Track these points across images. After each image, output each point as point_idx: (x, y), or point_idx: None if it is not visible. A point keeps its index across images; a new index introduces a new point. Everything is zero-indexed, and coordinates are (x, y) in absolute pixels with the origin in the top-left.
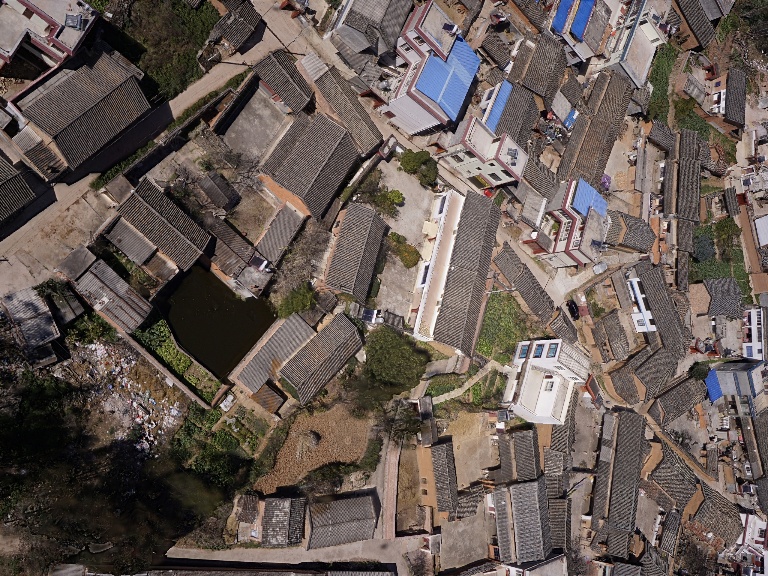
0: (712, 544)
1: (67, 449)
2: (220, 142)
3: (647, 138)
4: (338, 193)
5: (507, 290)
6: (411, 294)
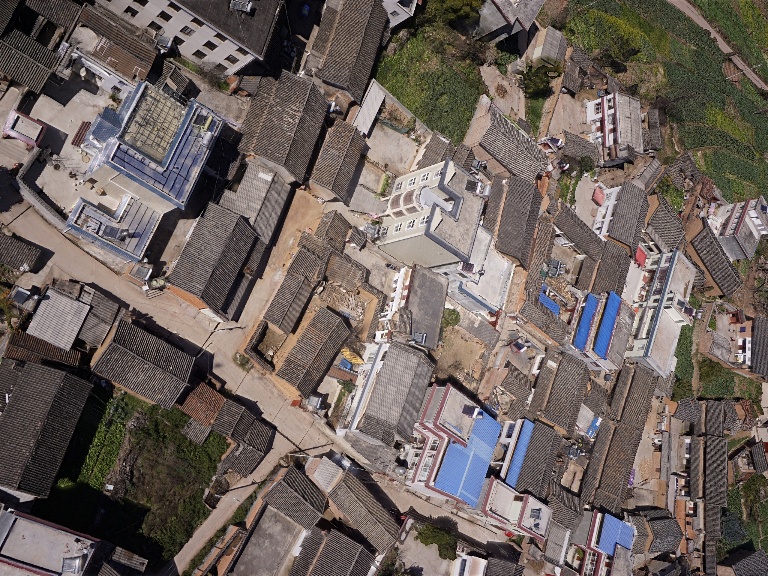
0: None
1: None
2: None
3: (672, 415)
4: None
5: None
6: None
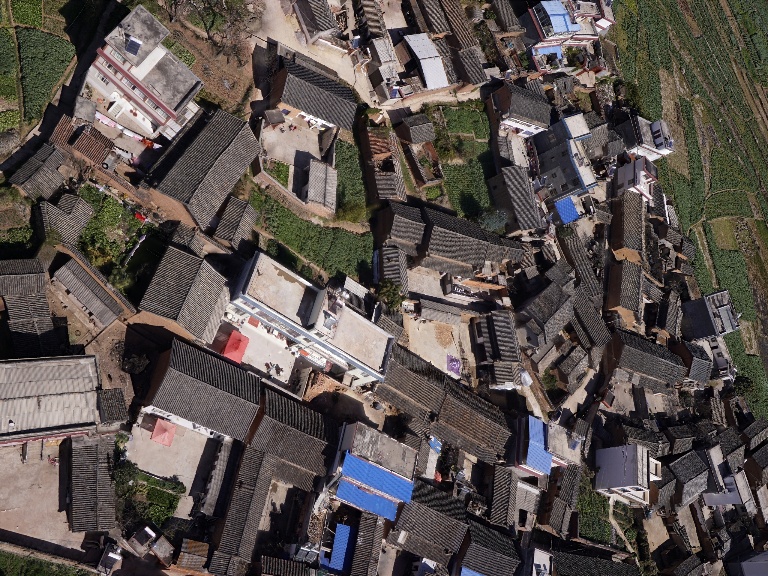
0: None
1: None
2: None
3: None
4: None
5: None
6: None
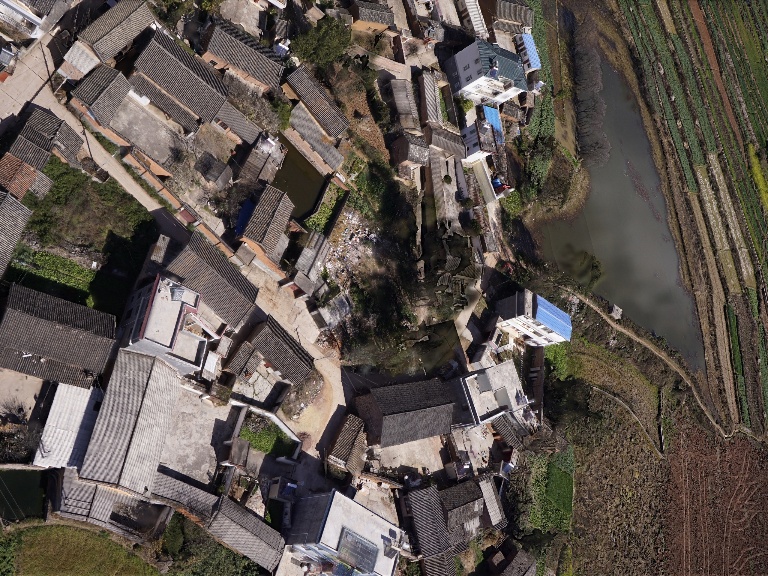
0: None
1: None
2: None
3: None
4: None
5: None
6: None
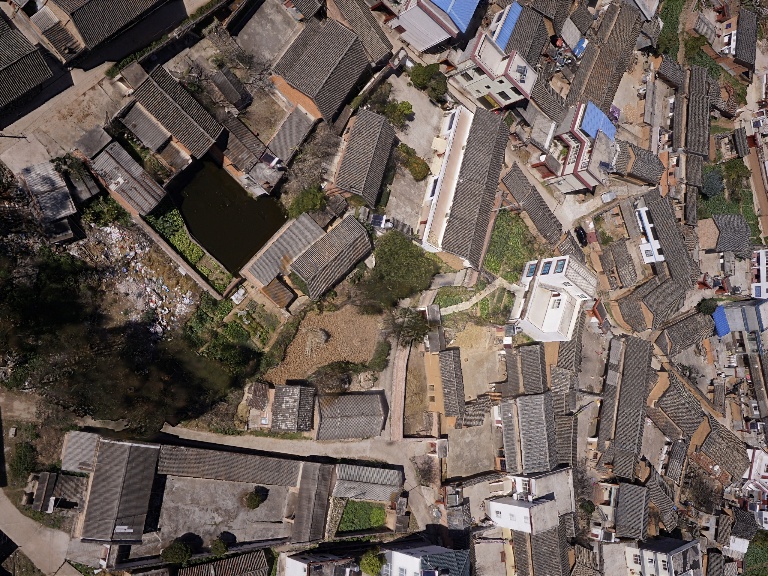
0: (718, 478)
1: (82, 325)
2: (233, 41)
3: (657, 73)
4: (348, 101)
5: (515, 209)
6: (420, 207)
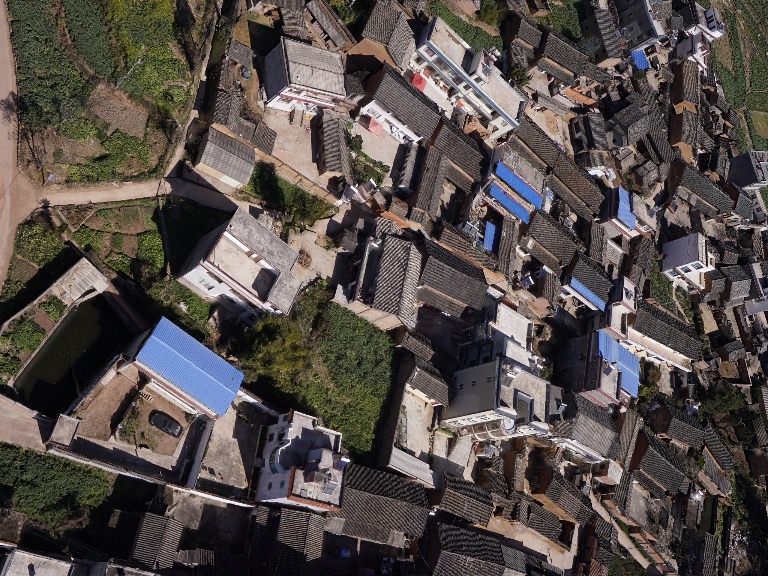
0: None
1: None
2: None
3: None
4: None
5: None
6: (661, 367)
